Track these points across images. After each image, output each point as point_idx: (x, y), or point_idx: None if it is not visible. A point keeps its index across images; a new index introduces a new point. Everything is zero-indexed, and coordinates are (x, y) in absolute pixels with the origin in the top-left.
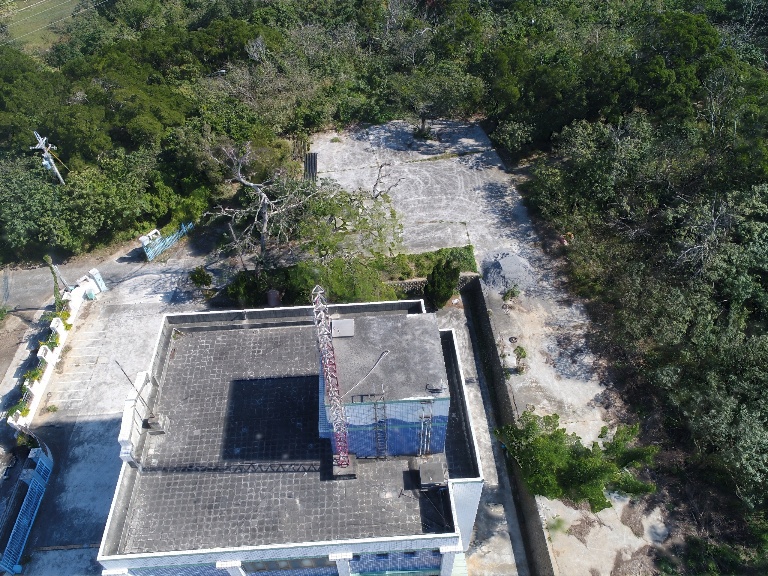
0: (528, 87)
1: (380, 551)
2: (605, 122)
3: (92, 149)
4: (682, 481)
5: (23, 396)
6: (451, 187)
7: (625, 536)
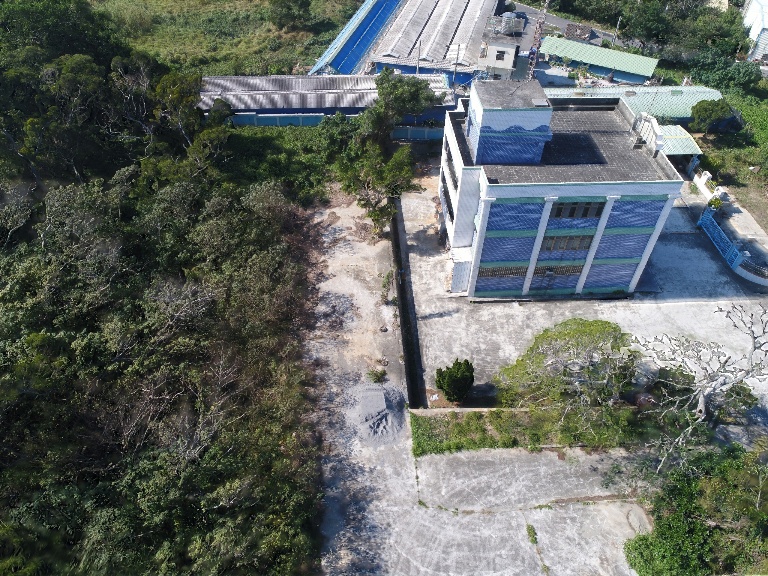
0: None
1: None
2: None
3: None
4: None
5: None
6: None
7: (341, 212)
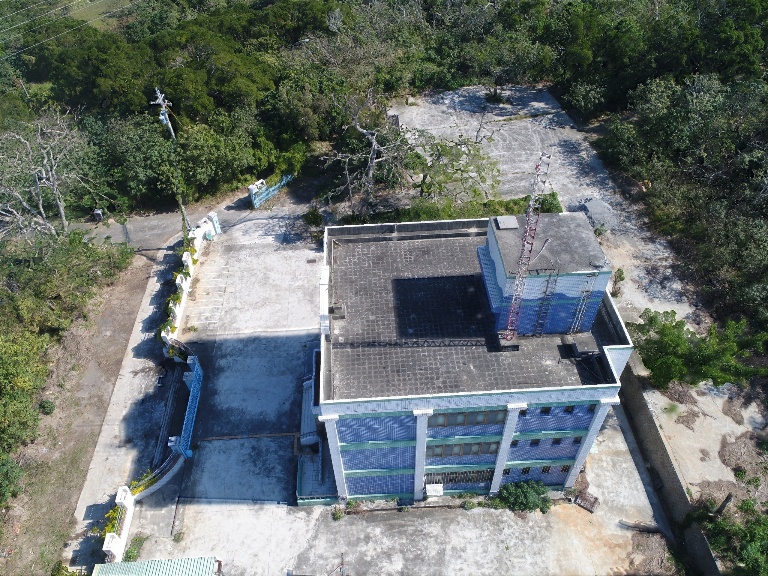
0: (598, 52)
1: (548, 404)
2: (675, 81)
3: (197, 108)
4: None
5: (170, 316)
6: (528, 144)
7: (728, 424)
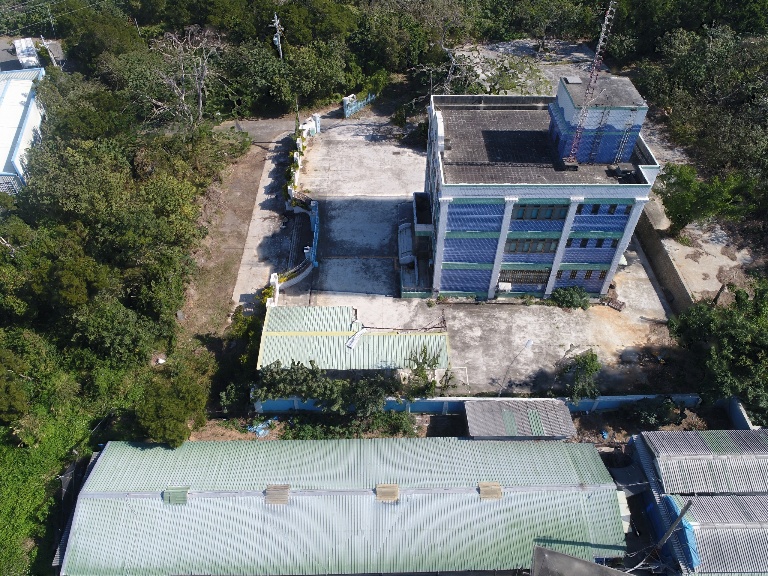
0: (632, 10)
1: (598, 201)
2: (696, 33)
3: (299, 38)
4: (761, 237)
5: None
6: None
7: (724, 260)
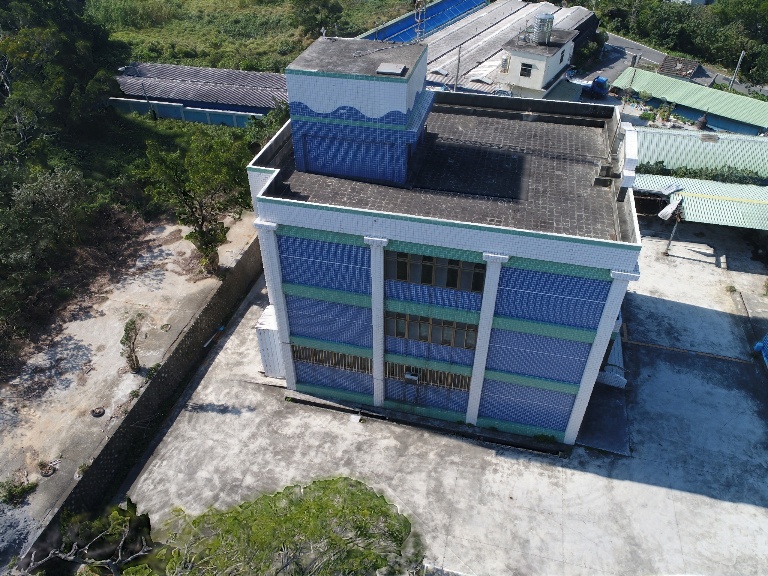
0: None
1: None
2: None
3: None
4: None
5: None
6: None
7: None
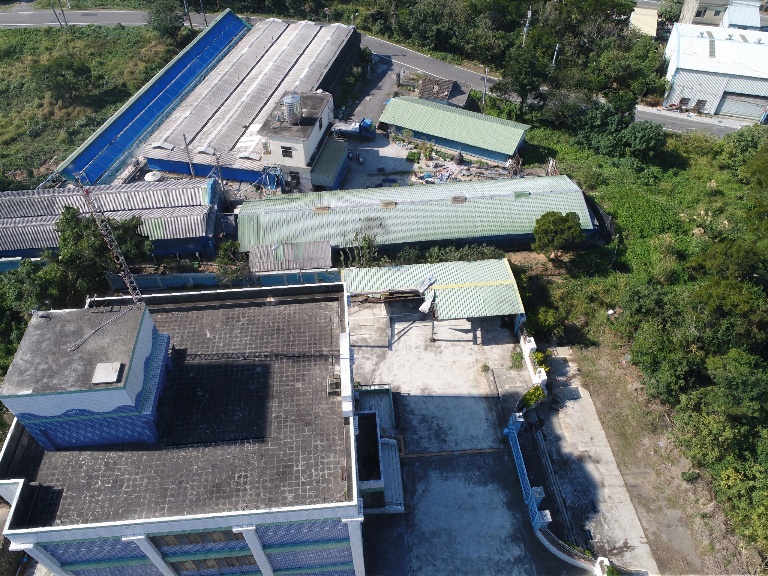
0: None
1: None
2: None
3: None
4: None
5: None
6: None
7: None
